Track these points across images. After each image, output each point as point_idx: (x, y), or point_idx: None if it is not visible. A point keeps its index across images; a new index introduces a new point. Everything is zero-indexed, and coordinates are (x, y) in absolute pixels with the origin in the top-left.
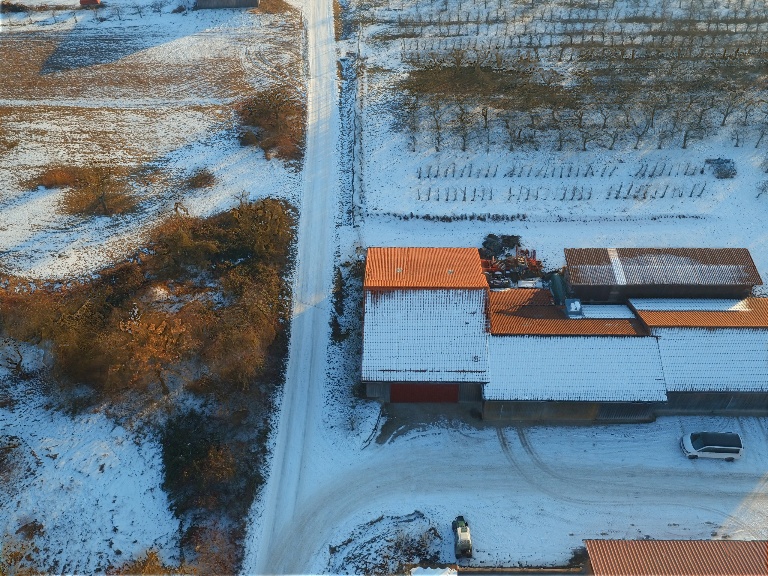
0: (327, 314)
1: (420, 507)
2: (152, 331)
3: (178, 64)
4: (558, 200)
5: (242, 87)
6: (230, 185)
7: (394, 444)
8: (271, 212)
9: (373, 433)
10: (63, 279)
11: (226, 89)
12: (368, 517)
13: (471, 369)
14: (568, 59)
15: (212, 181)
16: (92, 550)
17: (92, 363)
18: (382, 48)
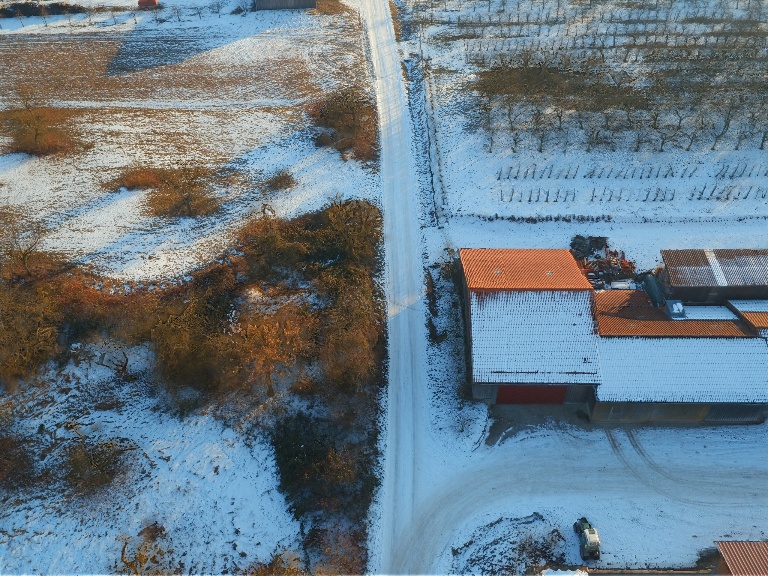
0: (422, 315)
1: (538, 509)
2: (266, 333)
3: (243, 65)
4: (641, 201)
5: (310, 88)
6: (310, 186)
7: (504, 446)
8: (367, 213)
9: (483, 435)
10: (156, 281)
11: (294, 90)
12: (488, 519)
13: (582, 371)
14: (633, 60)
15: (292, 182)
16: (216, 552)
17: (201, 365)
18: (445, 49)
